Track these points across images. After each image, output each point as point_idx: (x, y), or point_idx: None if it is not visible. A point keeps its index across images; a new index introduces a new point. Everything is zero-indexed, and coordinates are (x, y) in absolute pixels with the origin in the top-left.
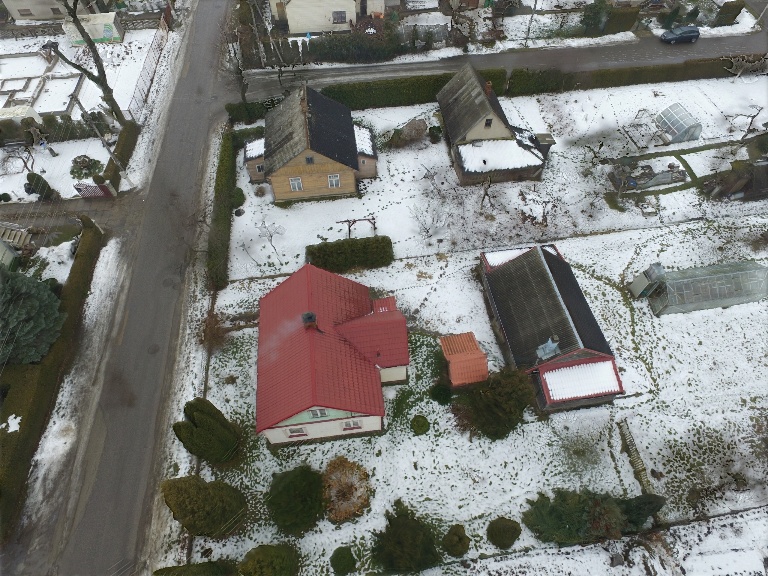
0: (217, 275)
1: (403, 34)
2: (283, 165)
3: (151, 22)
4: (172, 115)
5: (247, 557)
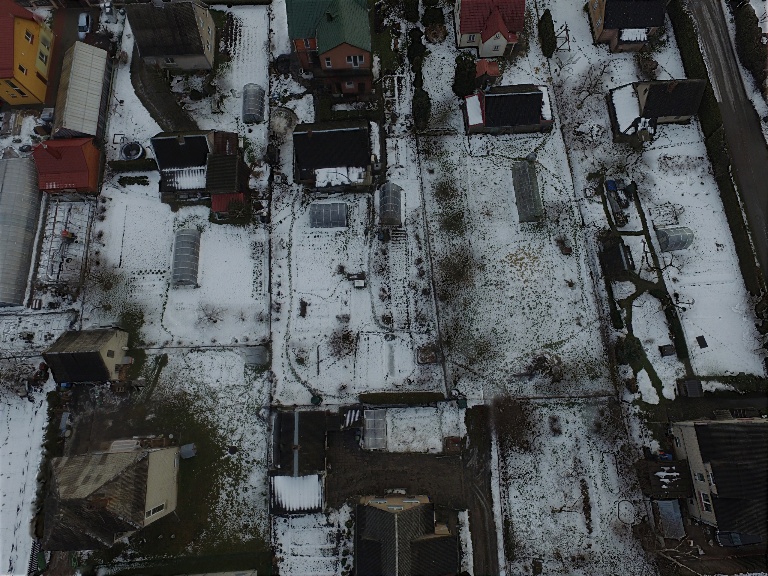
0: None
1: None
2: None
3: None
4: None
5: None
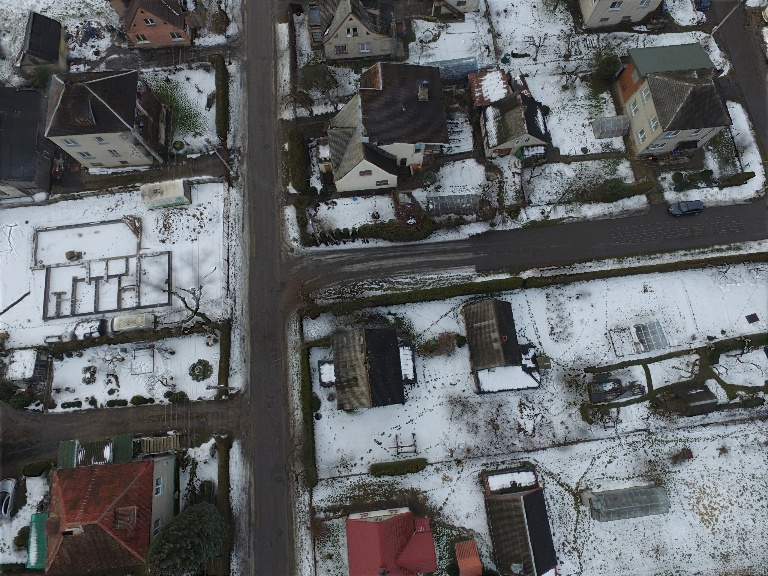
0: None
1: (439, 210)
2: (352, 408)
3: (213, 179)
4: (252, 307)
5: None
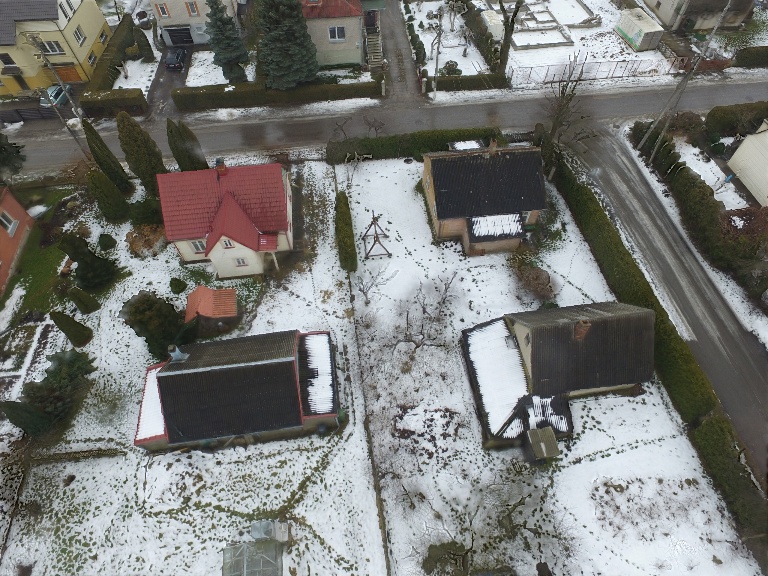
0: (327, 149)
1: None
2: None
3: None
4: (531, 101)
5: (100, 173)
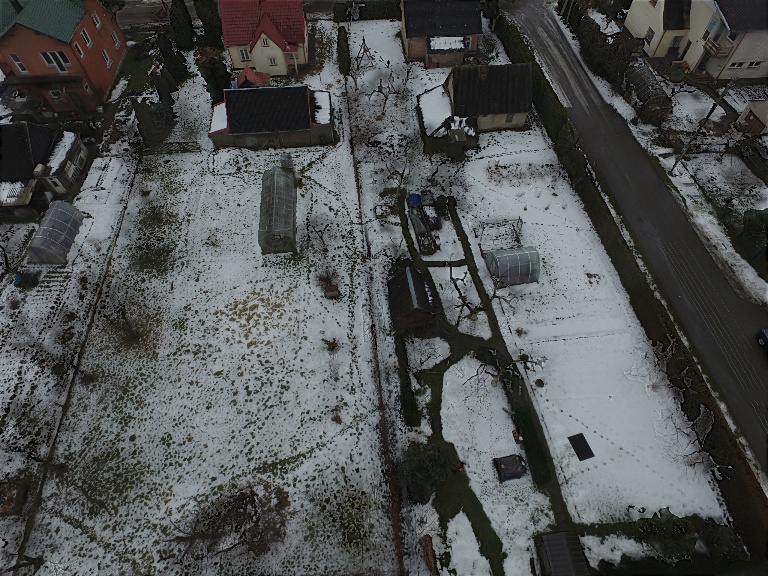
0: (334, 9)
1: (635, 72)
2: None
3: None
4: None
5: (178, 9)
